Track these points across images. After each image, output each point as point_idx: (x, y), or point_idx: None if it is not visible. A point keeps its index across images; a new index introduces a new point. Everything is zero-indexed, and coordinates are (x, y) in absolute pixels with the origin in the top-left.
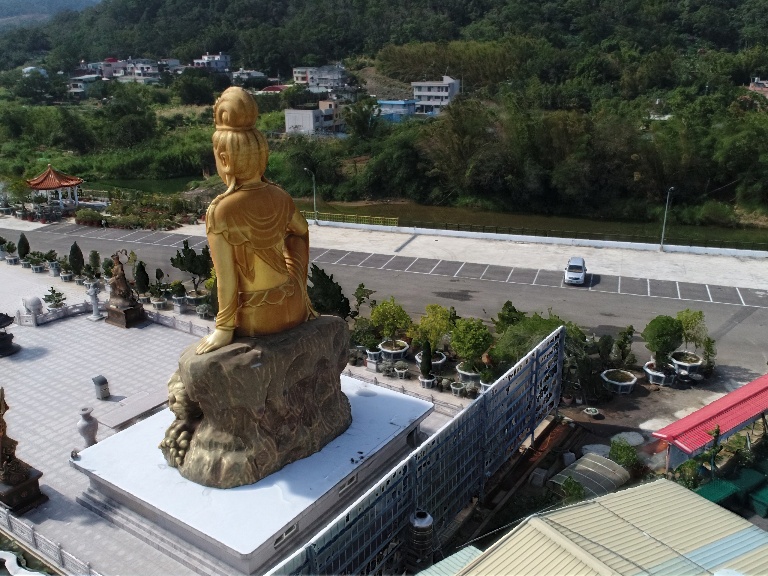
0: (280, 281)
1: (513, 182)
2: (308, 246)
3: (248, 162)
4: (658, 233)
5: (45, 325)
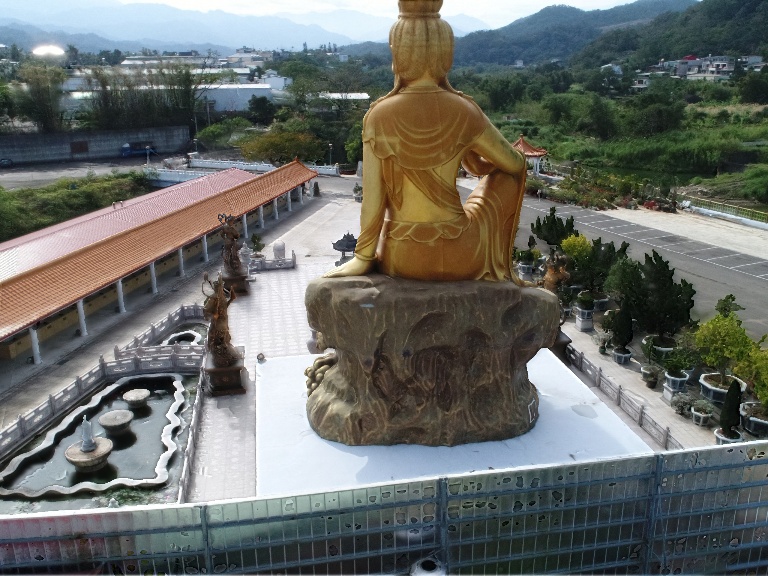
0: (438, 216)
1: None
2: (521, 189)
3: (410, 57)
4: None
5: None
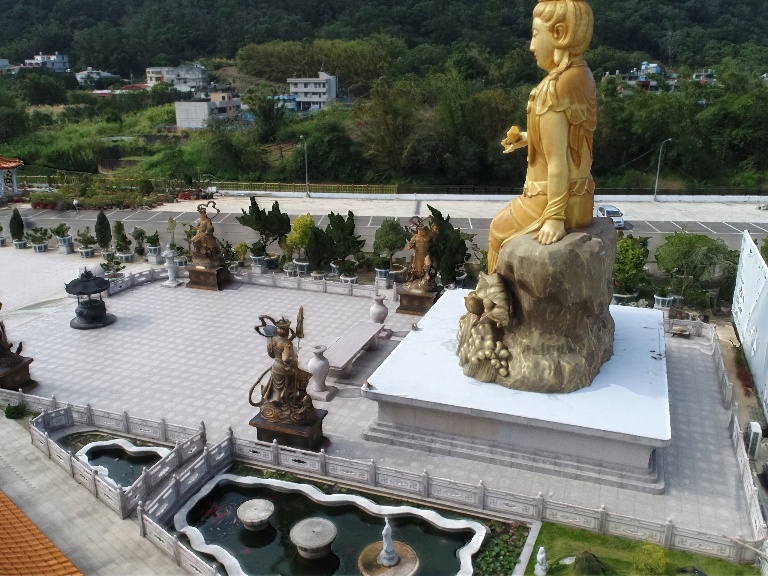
0: None
1: (450, 160)
2: None
3: (585, 34)
4: (651, 185)
5: (117, 295)
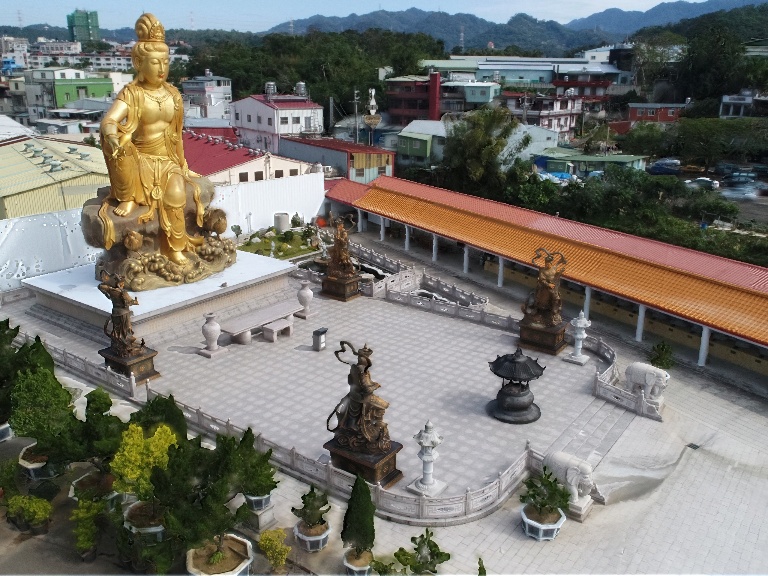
0: None
1: None
2: None
3: None
4: None
5: None
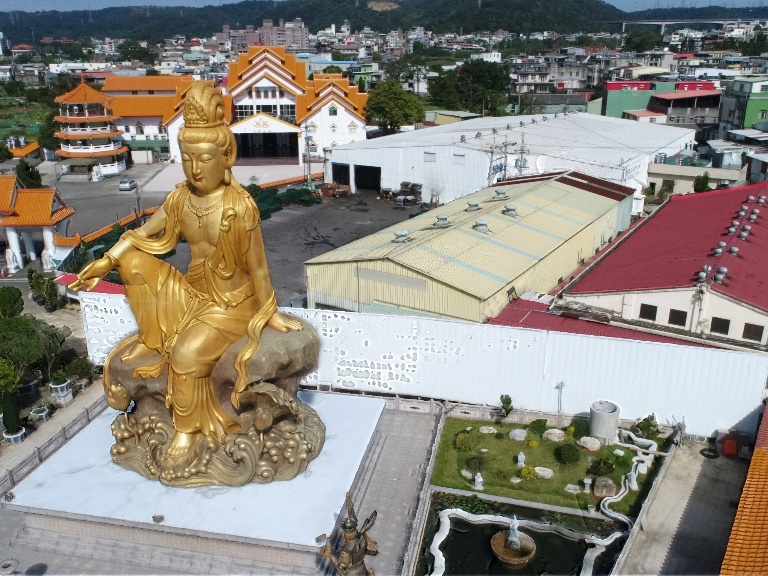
0: None
1: None
2: None
3: None
4: None
5: None
